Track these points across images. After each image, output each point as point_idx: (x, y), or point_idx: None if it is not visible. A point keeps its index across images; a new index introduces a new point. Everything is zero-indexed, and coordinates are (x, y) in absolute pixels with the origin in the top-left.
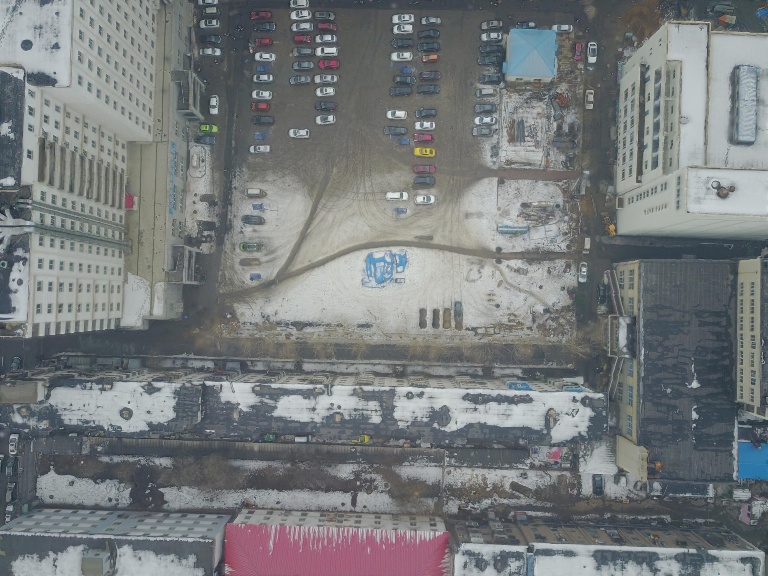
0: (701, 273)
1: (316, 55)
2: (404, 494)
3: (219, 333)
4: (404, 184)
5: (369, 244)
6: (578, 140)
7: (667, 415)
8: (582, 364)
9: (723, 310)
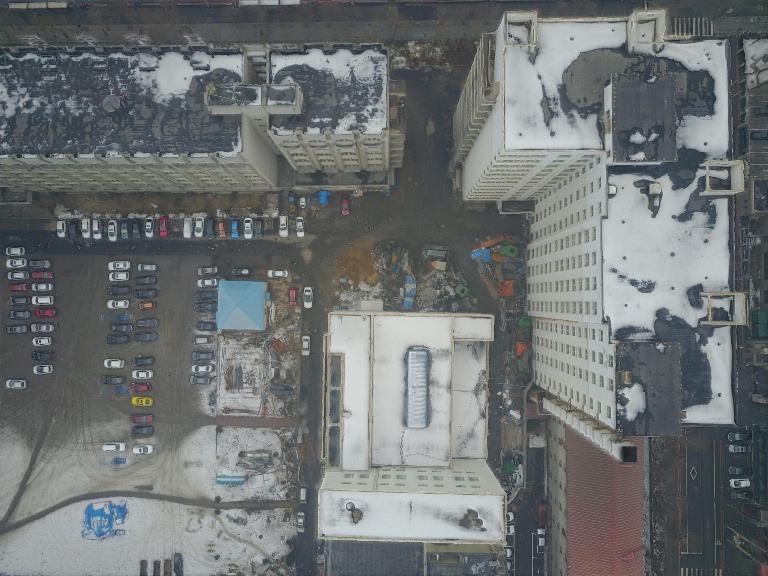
0: (387, 551)
1: (32, 303)
2: None
3: None
4: (123, 433)
5: (89, 495)
6: (296, 386)
7: None
8: None
9: None
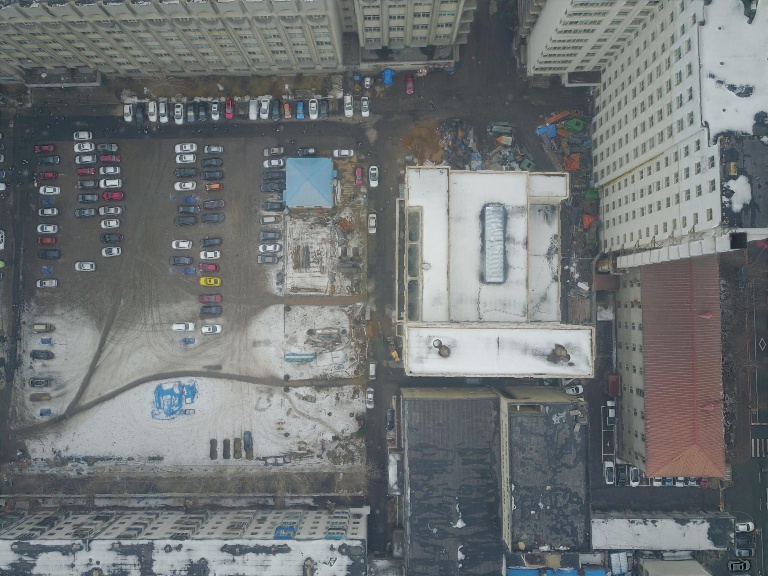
0: (463, 410)
1: (100, 187)
2: None
3: (10, 470)
4: (191, 314)
5: (158, 375)
6: (363, 264)
7: (434, 555)
8: (373, 491)
9: (487, 447)
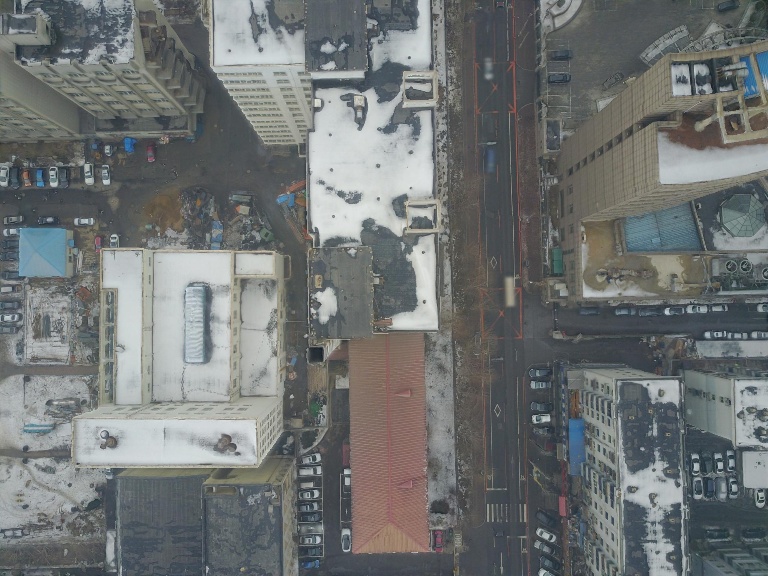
0: (174, 488)
1: None
2: None
3: None
4: None
5: None
6: None
7: None
8: None
9: (198, 524)
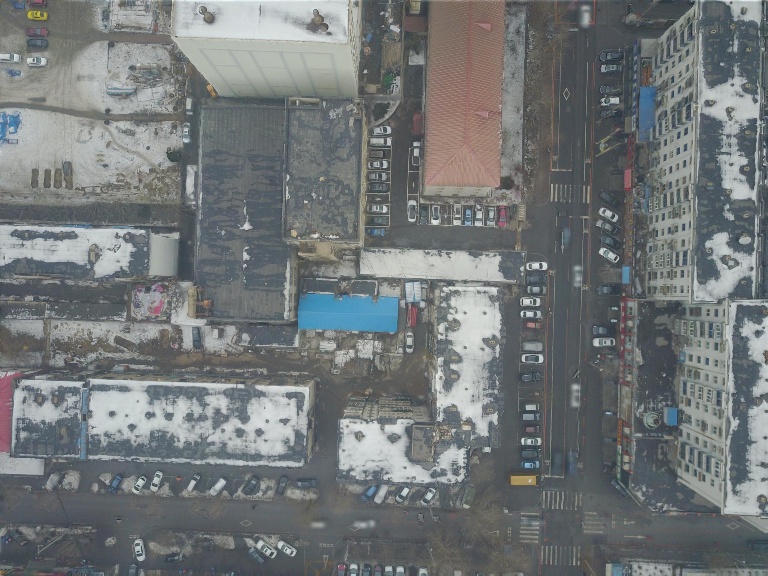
0: (255, 119)
1: None
2: (13, 348)
3: None
4: (19, 47)
5: None
6: None
7: (221, 256)
8: (186, 223)
9: (277, 155)
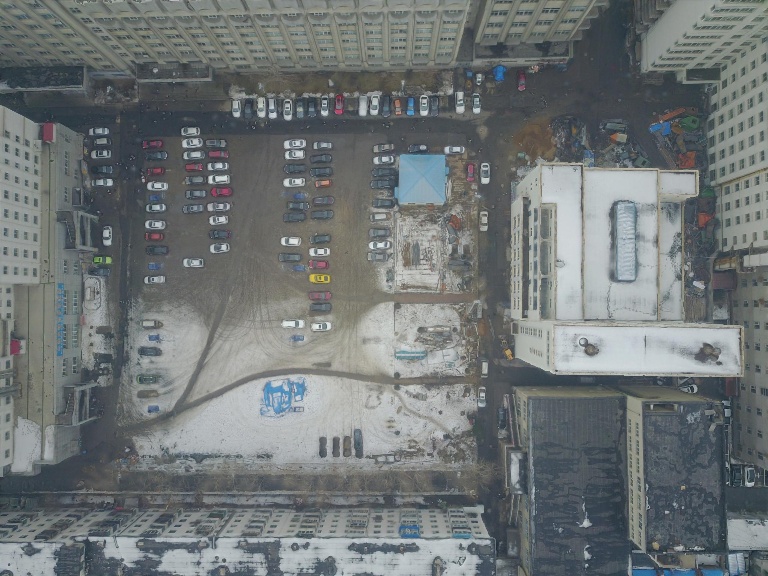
0: (589, 409)
1: (208, 183)
2: None
3: (118, 467)
4: (300, 311)
5: (267, 373)
6: (474, 262)
7: (559, 555)
8: None
9: (613, 446)
